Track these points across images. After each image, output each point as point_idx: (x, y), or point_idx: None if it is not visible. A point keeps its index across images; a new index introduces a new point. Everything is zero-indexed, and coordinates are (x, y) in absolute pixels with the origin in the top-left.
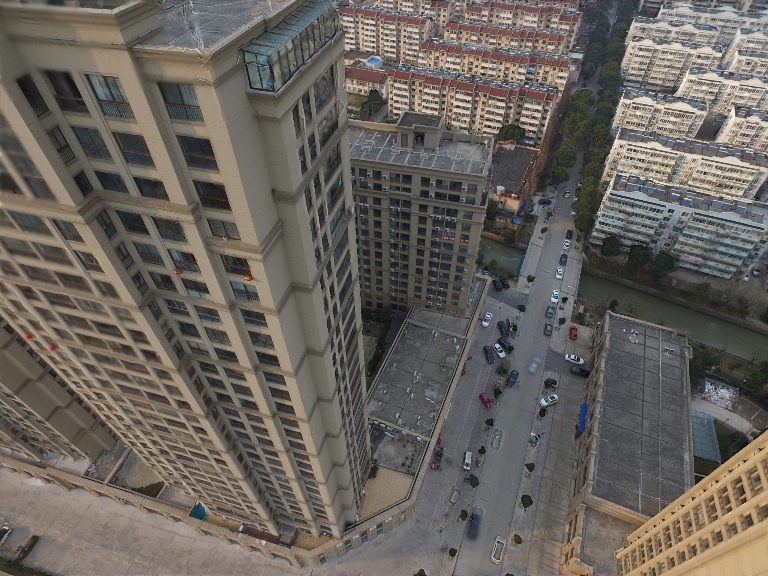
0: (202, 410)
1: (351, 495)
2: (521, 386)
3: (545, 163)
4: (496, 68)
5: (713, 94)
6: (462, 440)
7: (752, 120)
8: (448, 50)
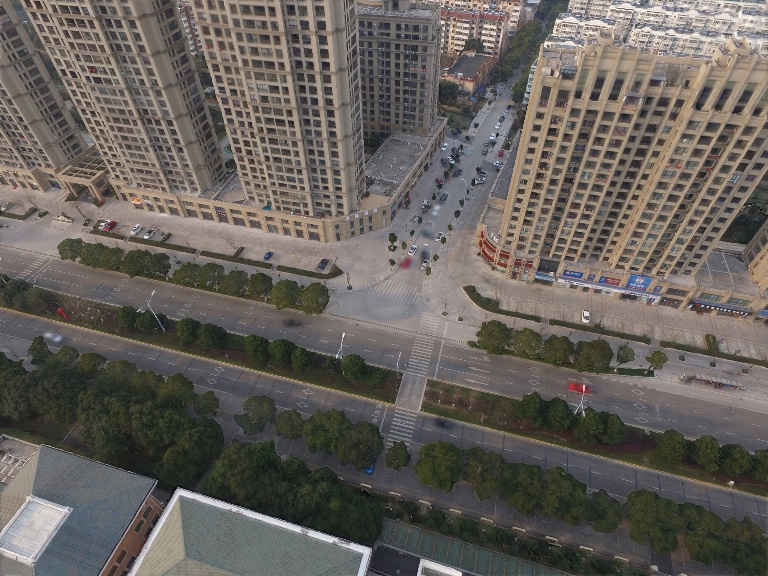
0: (290, 67)
1: (354, 179)
2: (463, 176)
3: (499, 69)
4: (466, 5)
5: (628, 20)
6: (423, 198)
7: (645, 30)
8: None
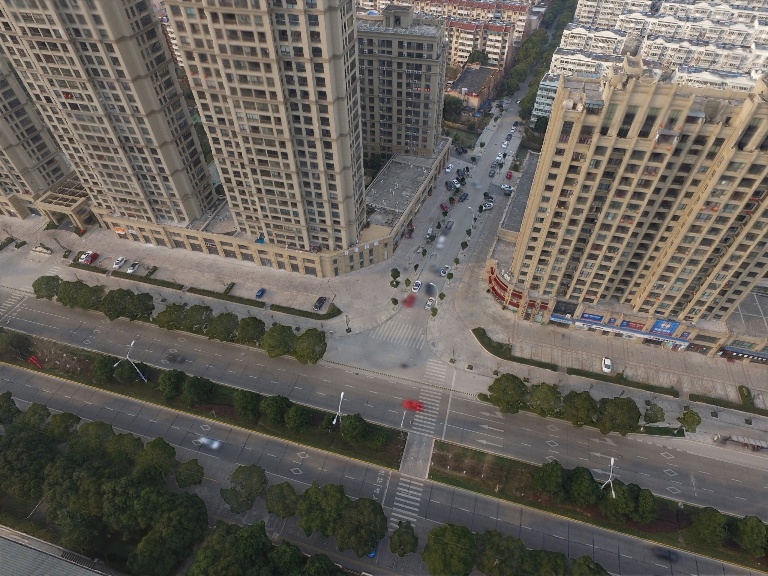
0: (282, 97)
1: (353, 211)
2: (469, 201)
3: (504, 82)
4: (470, 14)
5: (639, 30)
6: (427, 226)
7: (658, 42)
8: (431, 1)
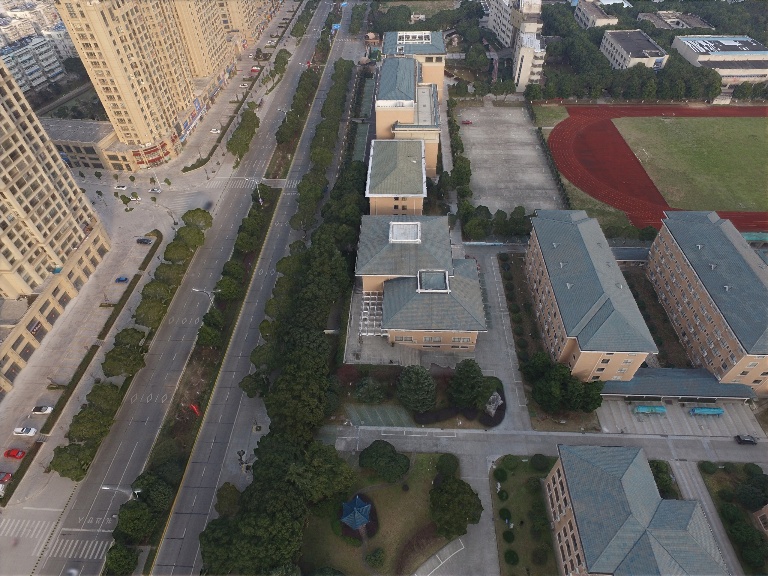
0: None
1: None
2: None
3: None
4: None
5: None
6: None
7: None
8: None
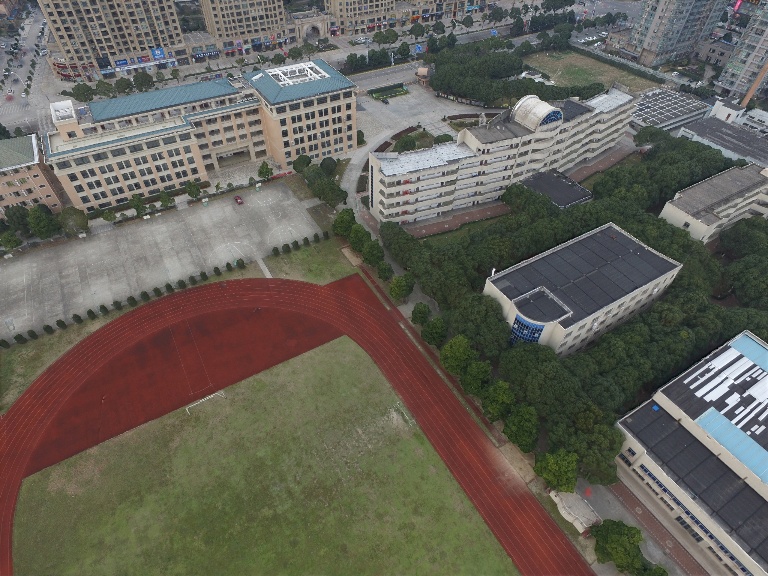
0: None
1: None
2: None
3: (26, 1)
4: None
5: None
6: (2, 71)
7: None
8: None
